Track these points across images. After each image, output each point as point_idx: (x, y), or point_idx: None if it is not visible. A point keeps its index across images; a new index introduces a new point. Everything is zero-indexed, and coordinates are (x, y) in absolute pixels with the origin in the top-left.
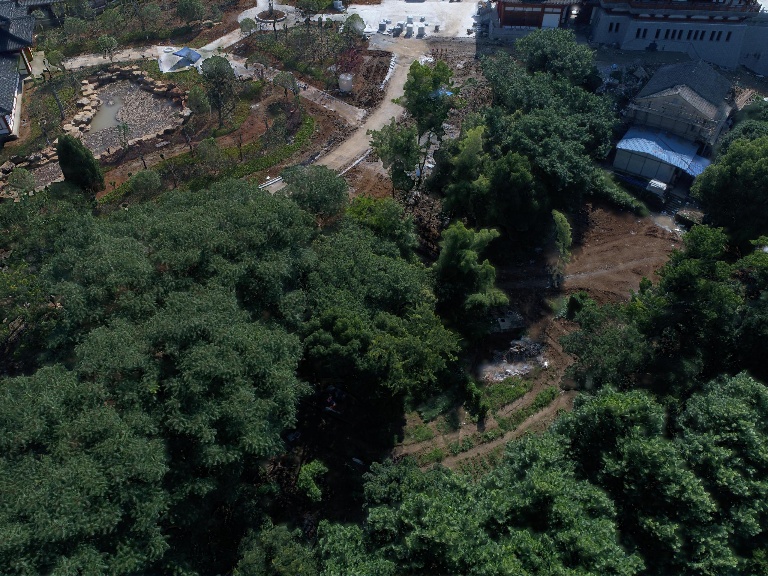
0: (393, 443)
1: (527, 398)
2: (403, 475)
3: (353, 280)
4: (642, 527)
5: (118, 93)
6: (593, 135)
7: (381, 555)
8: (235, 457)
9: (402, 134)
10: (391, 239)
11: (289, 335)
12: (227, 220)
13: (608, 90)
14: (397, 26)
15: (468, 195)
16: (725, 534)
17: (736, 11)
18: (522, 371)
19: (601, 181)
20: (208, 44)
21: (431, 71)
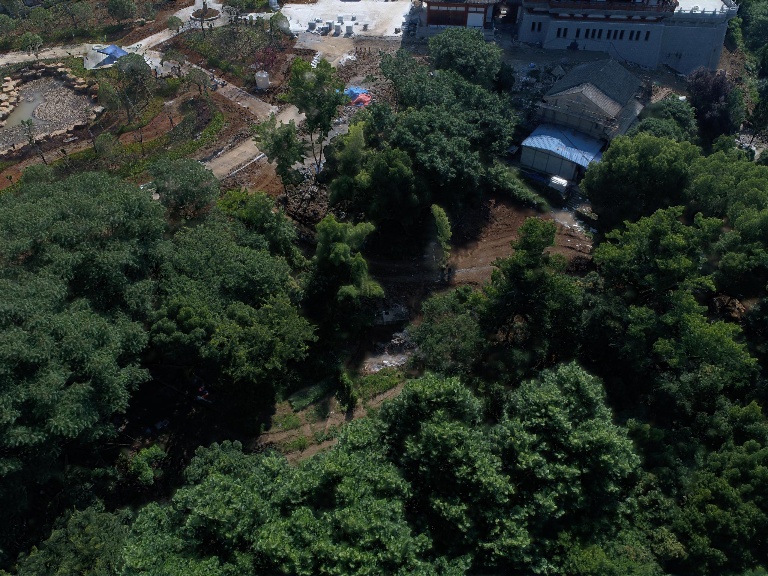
0: (259, 431)
1: (399, 388)
2: (216, 458)
3: (207, 271)
4: (432, 507)
5: (40, 90)
6: (488, 132)
7: (180, 534)
8: (39, 438)
9: (281, 129)
10: (262, 232)
11: (133, 323)
12: (70, 211)
13: (524, 88)
14: (325, 25)
15: (351, 190)
16: (522, 515)
17: (652, 11)
18: (399, 362)
19: (503, 177)
20: (138, 42)
21: (351, 69)
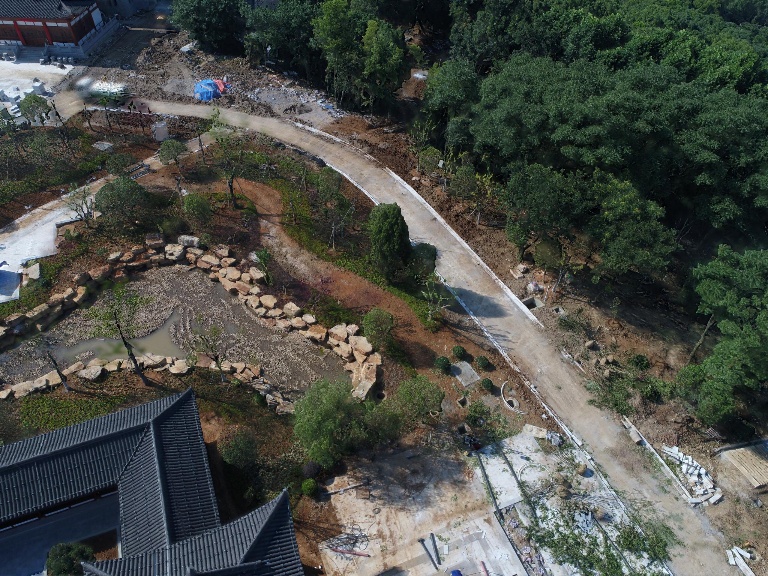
0: None
1: None
2: None
3: None
4: None
5: None
6: None
7: None
8: None
9: None
10: None
11: None
12: None
13: None
14: None
15: None
16: None
17: None
18: None
19: None
20: None
21: (146, 90)
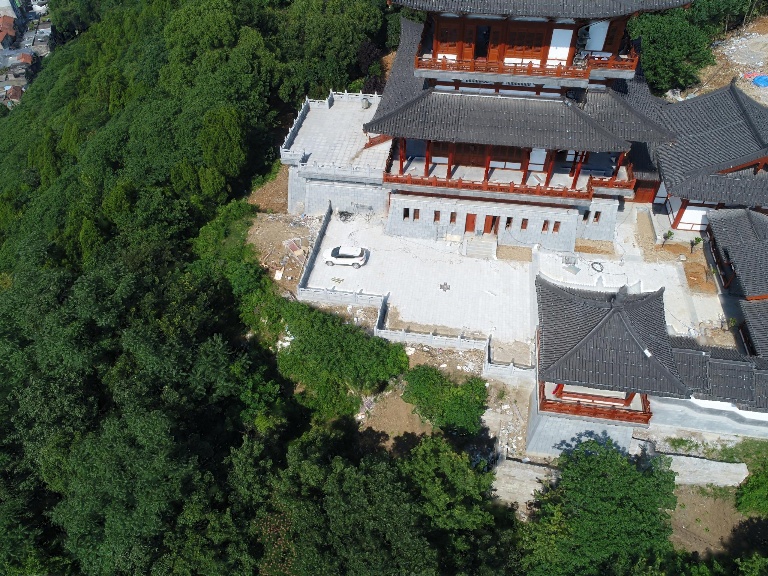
0: None
1: None
2: None
3: None
4: None
5: None
6: None
7: None
8: None
9: None
10: None
11: None
12: None
13: None
14: None
15: None
16: None
17: None
18: None
19: None
20: None
21: None
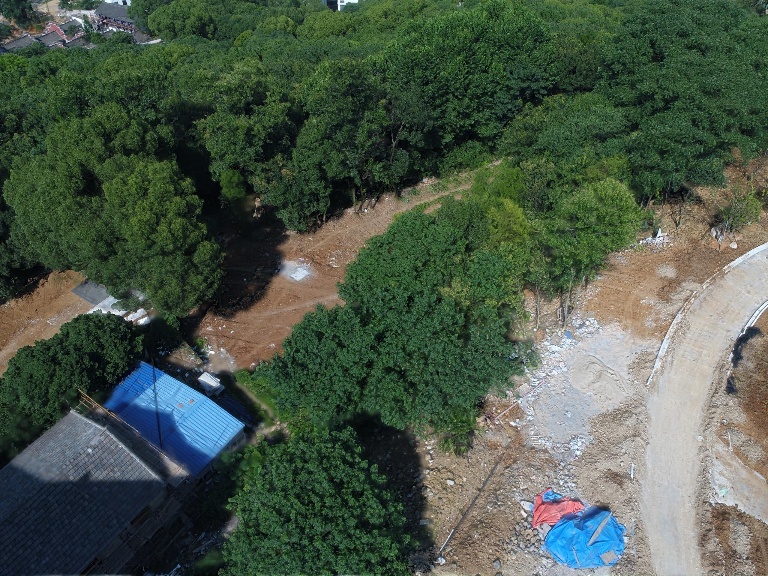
0: None
1: (431, 210)
2: None
3: None
4: None
5: None
6: None
7: None
8: None
9: None
10: None
11: None
12: None
13: None
14: None
15: None
16: None
17: None
18: None
19: None
20: None
21: None
